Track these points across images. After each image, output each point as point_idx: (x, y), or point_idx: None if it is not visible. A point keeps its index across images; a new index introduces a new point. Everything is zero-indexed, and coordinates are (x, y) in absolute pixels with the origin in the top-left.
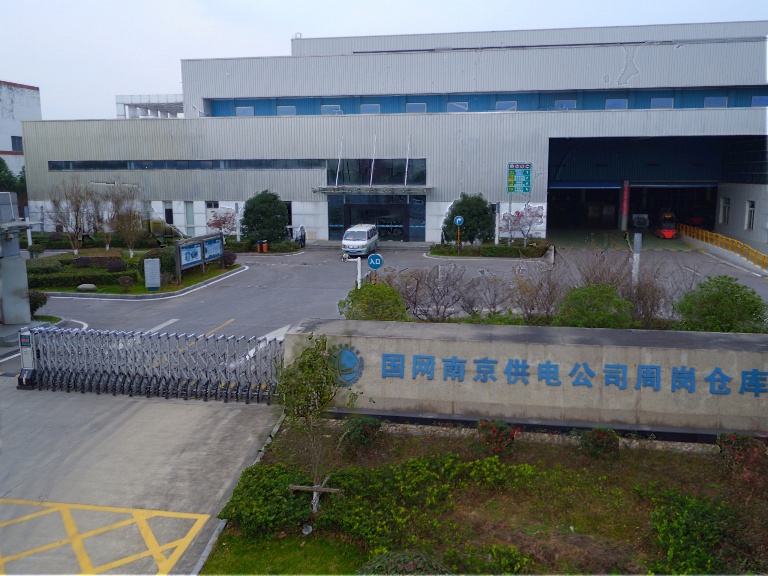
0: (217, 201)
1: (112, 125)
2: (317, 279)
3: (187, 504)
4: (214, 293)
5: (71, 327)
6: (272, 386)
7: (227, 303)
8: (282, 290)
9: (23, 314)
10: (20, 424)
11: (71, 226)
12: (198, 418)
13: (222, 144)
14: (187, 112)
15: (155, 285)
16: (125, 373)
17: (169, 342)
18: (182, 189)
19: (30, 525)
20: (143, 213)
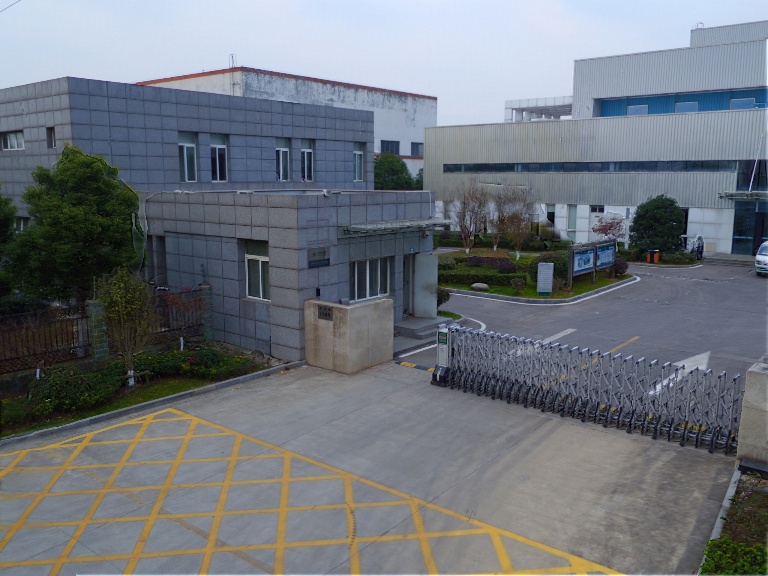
0: (603, 205)
1: (504, 129)
2: (729, 299)
3: (634, 566)
4: (608, 304)
5: (470, 326)
6: (716, 430)
7: (626, 317)
8: (688, 308)
9: (431, 308)
10: (438, 423)
11: (465, 226)
12: (624, 453)
13: (614, 145)
14: (580, 113)
15: (547, 290)
16: (538, 386)
17: (591, 359)
18: (567, 192)
19: (462, 543)
20: (533, 215)
